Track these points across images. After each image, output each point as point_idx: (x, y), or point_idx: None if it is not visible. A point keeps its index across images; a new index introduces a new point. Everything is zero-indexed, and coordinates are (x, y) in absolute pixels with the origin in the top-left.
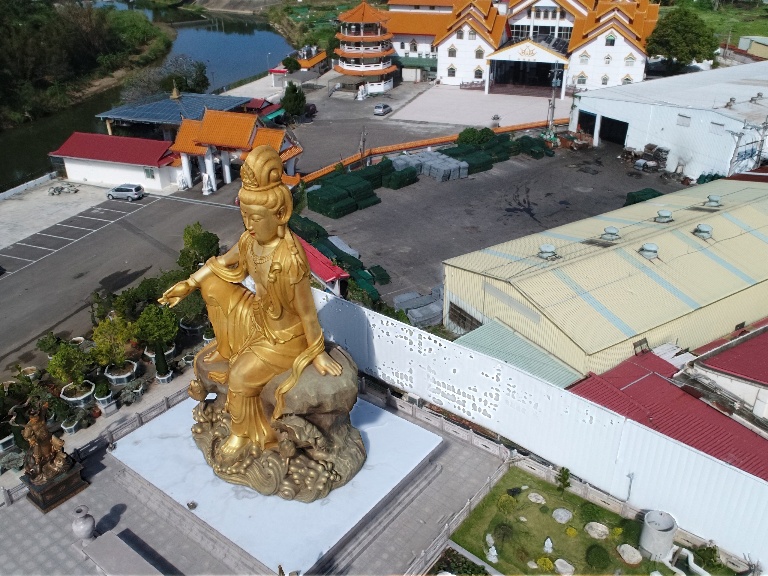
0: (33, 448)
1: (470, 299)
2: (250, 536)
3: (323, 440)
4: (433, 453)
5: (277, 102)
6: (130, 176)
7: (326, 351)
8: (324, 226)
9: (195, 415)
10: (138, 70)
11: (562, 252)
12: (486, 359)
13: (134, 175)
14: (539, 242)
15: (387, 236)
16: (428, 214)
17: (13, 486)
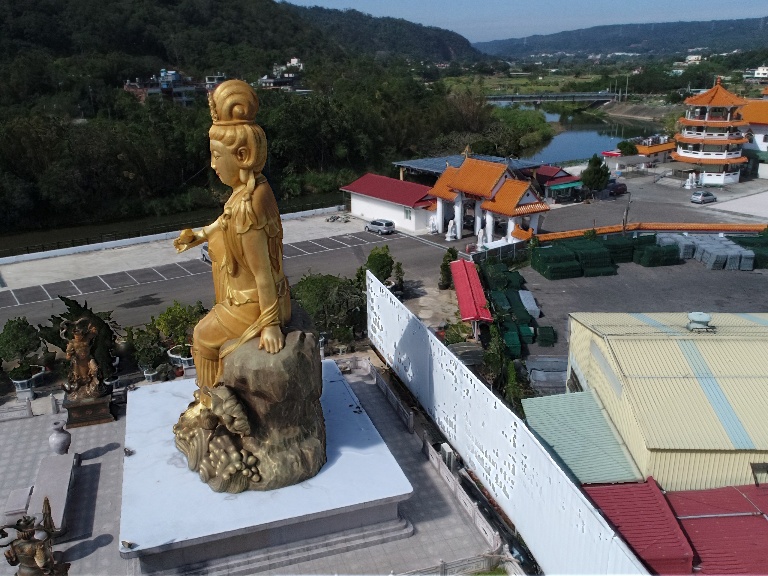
0: (74, 365)
1: (582, 363)
2: (139, 497)
3: (243, 423)
4: (390, 502)
5: (577, 174)
6: (394, 215)
7: (288, 331)
8: (532, 283)
9: (196, 378)
10: (453, 132)
11: (726, 329)
12: (505, 412)
13: (397, 214)
14: (716, 318)
15: (592, 305)
16: (663, 295)
17: None
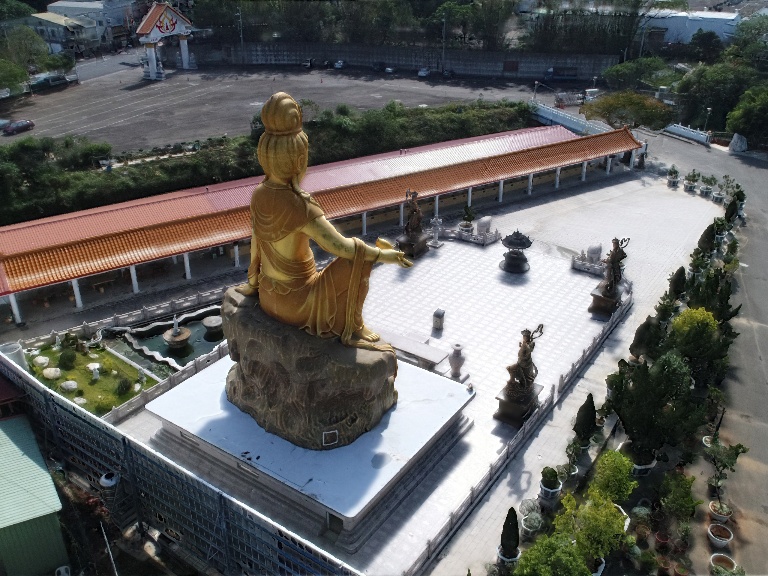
0: None
1: None
2: None
3: None
4: None
5: None
6: None
7: (249, 299)
8: None
9: None
10: None
11: None
12: None
13: None
14: None
15: None
16: None
17: (568, 420)
